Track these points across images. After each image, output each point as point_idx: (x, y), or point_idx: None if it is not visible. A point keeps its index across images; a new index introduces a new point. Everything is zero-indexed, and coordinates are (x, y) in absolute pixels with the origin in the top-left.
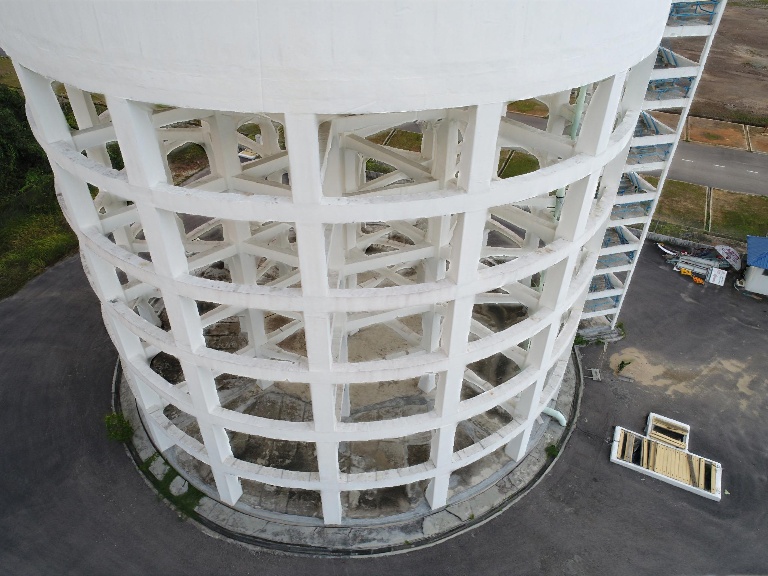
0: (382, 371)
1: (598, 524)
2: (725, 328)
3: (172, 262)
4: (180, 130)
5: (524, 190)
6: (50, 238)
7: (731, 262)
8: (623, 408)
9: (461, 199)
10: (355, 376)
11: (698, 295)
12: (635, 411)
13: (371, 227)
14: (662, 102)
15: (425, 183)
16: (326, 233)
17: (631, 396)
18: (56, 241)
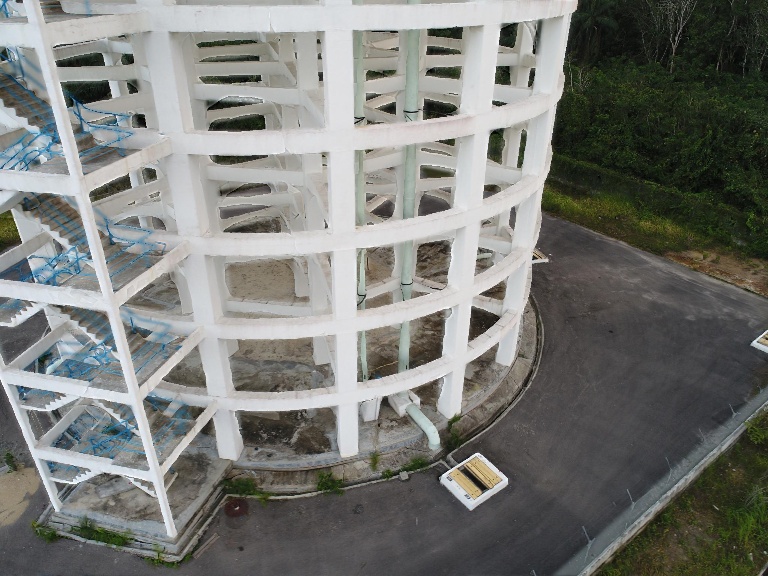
0: None
1: None
2: None
3: None
4: None
5: None
6: (571, 201)
7: None
8: None
9: None
10: None
11: None
12: None
13: (500, 369)
14: None
15: None
16: None
17: None
18: (568, 205)
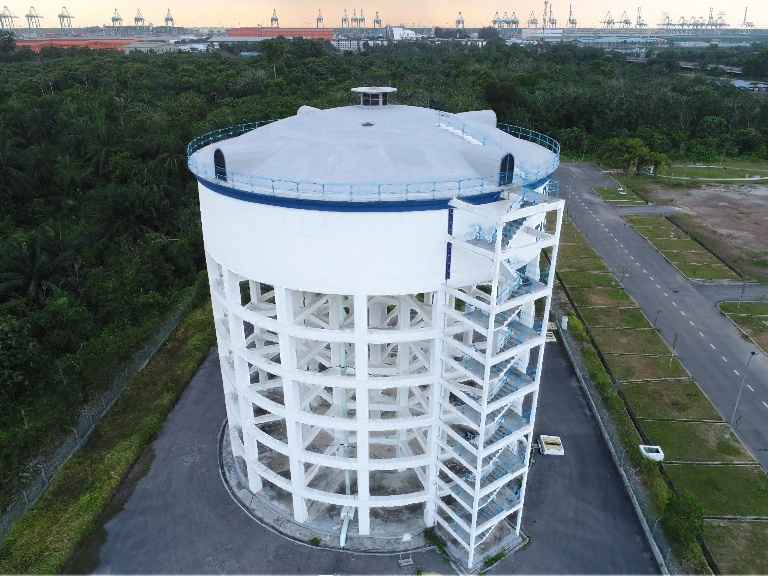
0: None
1: (264, 574)
2: None
3: None
4: None
5: None
6: None
7: None
8: None
9: (225, 302)
10: None
11: None
12: None
13: None
14: (467, 371)
15: (326, 324)
16: (263, 310)
17: None
18: None
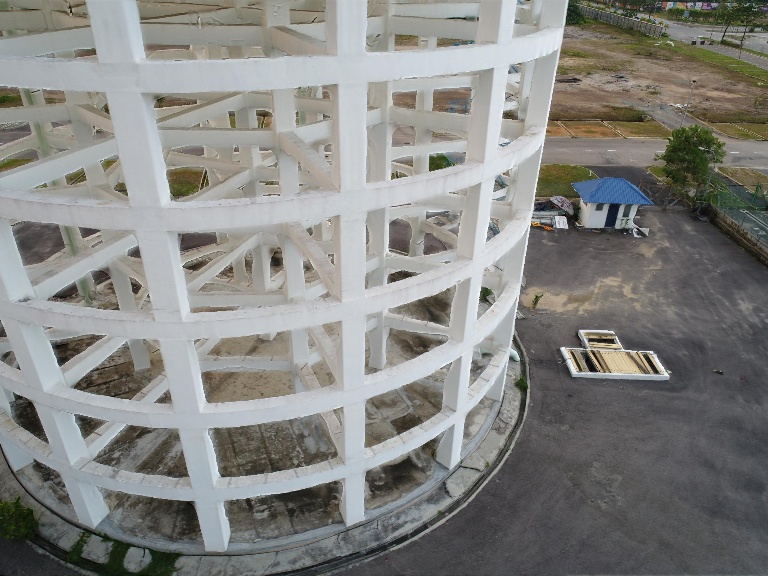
0: (417, 286)
1: (595, 430)
2: (589, 257)
3: (158, 181)
4: (33, 106)
5: (532, 48)
6: None
7: (565, 209)
8: (555, 334)
9: (492, 50)
10: (391, 298)
11: (555, 239)
12: (565, 333)
13: None
14: None
15: (368, 111)
16: (309, 151)
17: (555, 323)
18: None
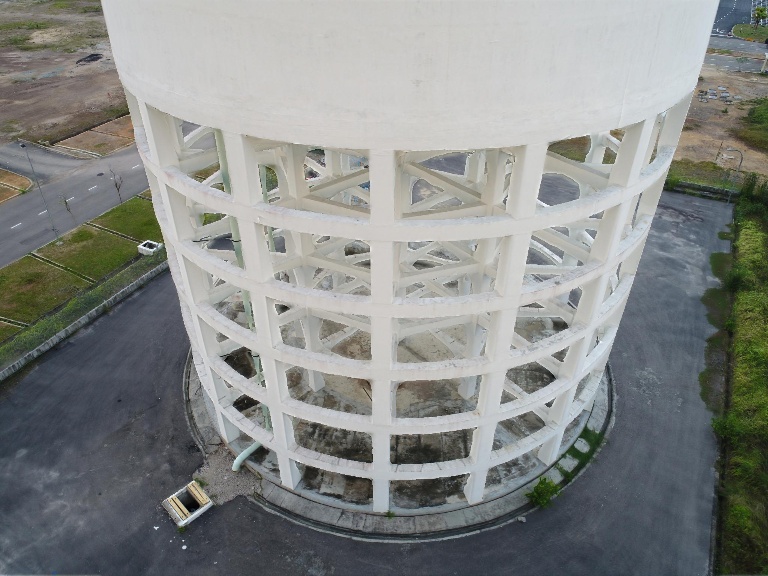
0: None
1: None
2: None
3: None
4: None
5: None
6: None
7: None
8: None
9: None
10: None
11: None
12: None
13: None
14: None
15: None
16: None
17: None
18: None
